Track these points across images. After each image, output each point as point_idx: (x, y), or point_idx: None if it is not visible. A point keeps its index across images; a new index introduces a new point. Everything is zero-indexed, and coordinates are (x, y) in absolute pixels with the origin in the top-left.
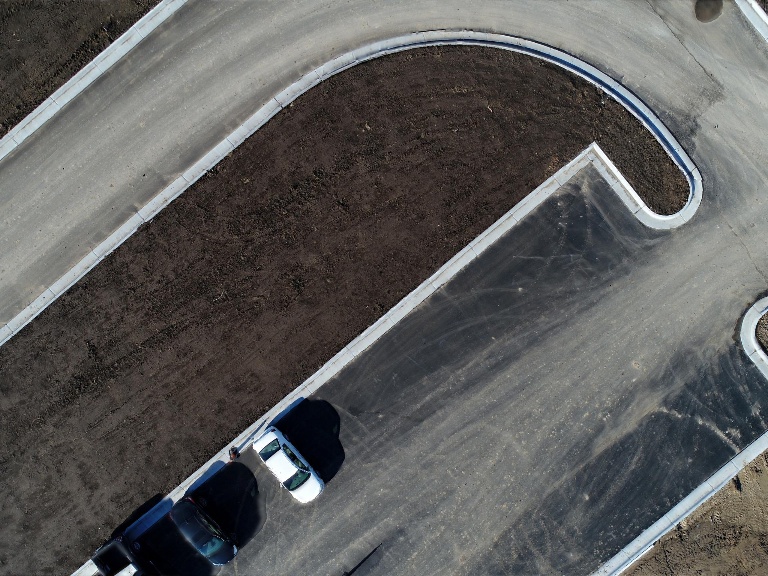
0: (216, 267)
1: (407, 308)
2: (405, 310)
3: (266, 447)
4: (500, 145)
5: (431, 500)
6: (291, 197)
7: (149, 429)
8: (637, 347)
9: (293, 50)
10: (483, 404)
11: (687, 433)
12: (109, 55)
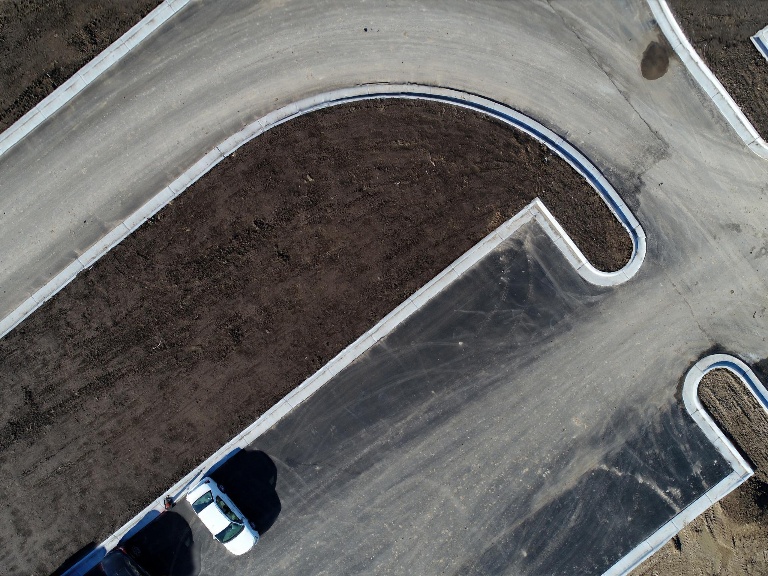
0: (155, 315)
1: (346, 360)
2: (344, 362)
3: (199, 499)
4: (442, 199)
5: (367, 554)
6: (231, 247)
7: (84, 477)
8: (578, 404)
9: (236, 100)
10: (421, 458)
11: (627, 491)
12: (52, 101)
